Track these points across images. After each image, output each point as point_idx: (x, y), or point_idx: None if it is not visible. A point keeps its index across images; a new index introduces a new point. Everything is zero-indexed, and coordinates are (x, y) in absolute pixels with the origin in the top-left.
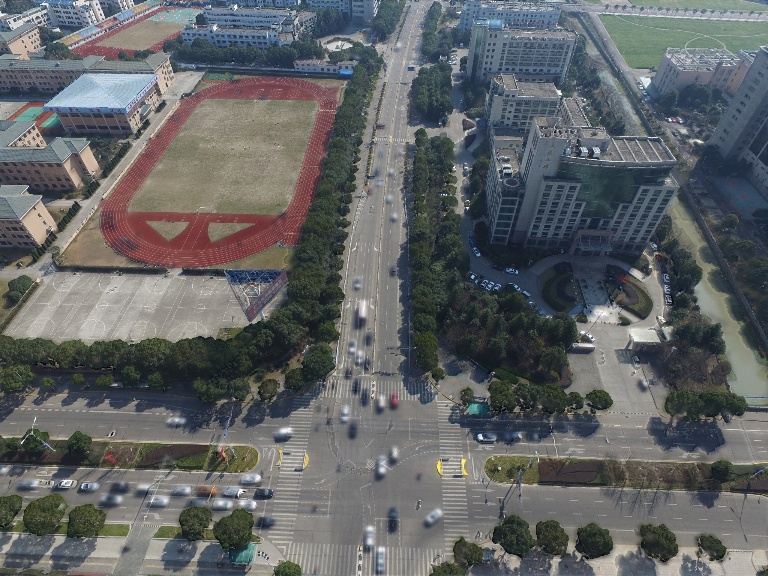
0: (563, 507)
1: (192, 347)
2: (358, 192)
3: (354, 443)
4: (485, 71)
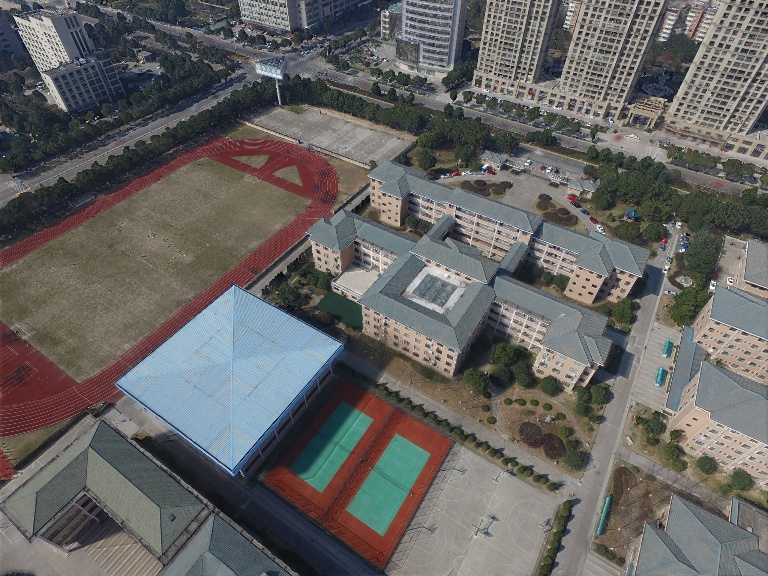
0: (239, 50)
1: (316, 83)
2: None
3: None
4: None
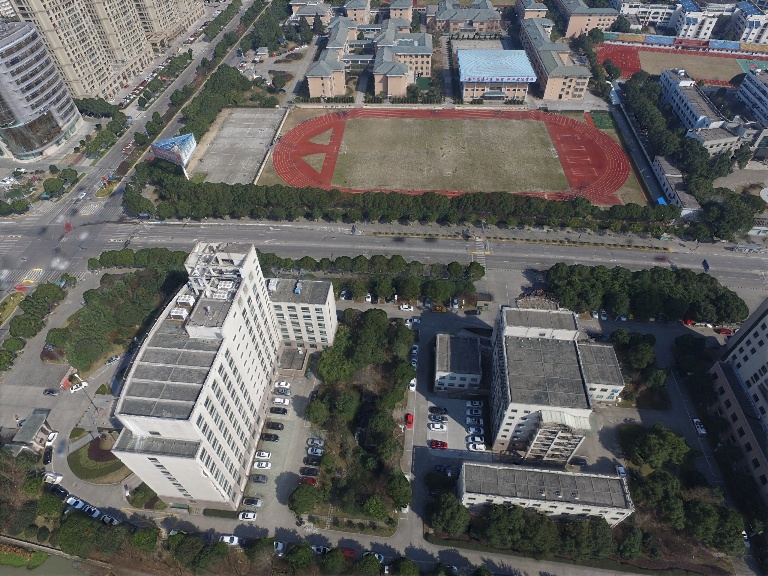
0: None
1: None
2: (362, 228)
3: (83, 232)
4: (732, 360)
